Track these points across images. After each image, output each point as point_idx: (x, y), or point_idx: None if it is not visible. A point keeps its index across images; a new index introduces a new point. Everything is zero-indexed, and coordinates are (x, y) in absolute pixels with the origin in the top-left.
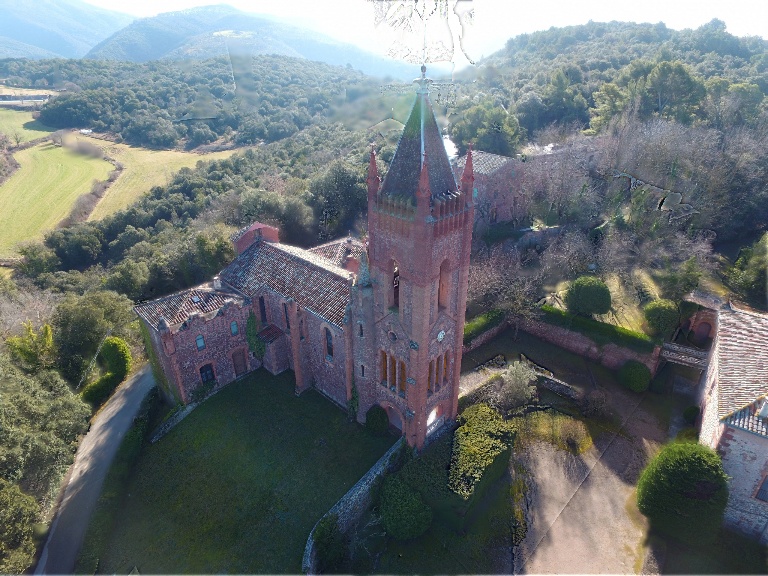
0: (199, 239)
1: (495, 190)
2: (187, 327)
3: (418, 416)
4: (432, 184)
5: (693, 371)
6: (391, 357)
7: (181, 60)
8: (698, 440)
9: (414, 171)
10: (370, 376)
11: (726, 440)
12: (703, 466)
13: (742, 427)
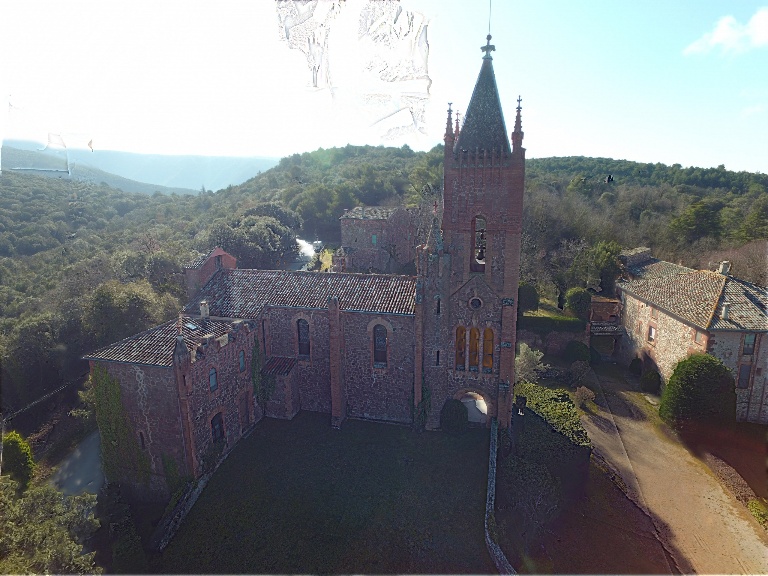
0: (101, 294)
1: (392, 235)
2: (203, 355)
3: (511, 386)
4: None
5: (599, 348)
6: (470, 331)
7: (131, 47)
8: (660, 376)
9: (494, 125)
10: (444, 363)
11: (711, 346)
12: (716, 364)
13: (722, 328)
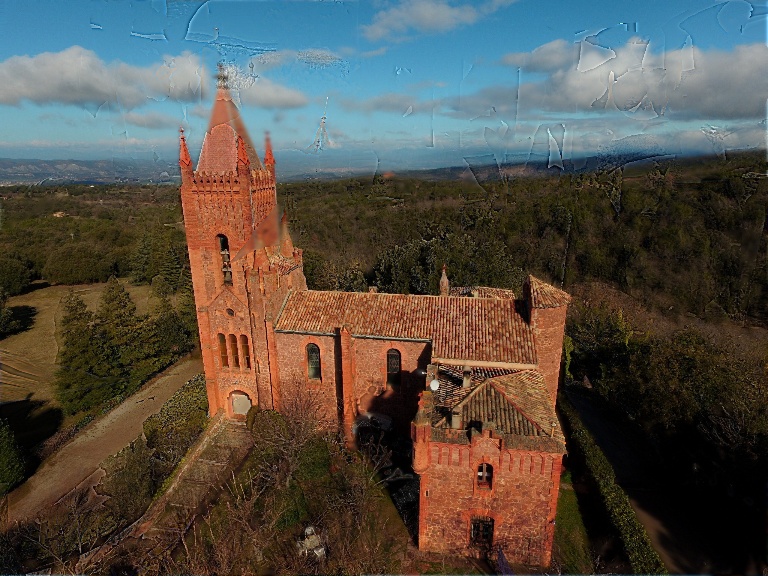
0: None
1: None
2: None
3: None
4: None
5: None
6: None
7: None
8: None
9: None
10: None
11: None
12: None
13: None
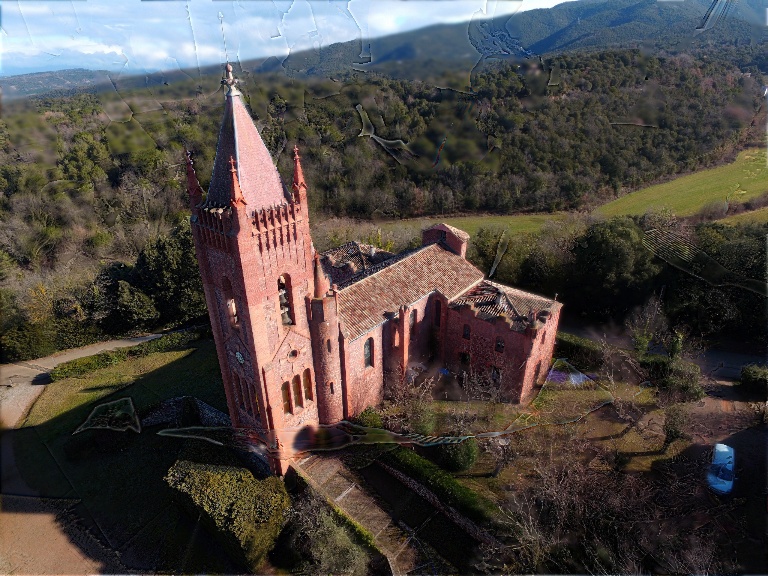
0: None
1: None
2: None
3: None
4: (218, 191)
5: None
6: None
7: None
8: None
9: None
10: None
11: None
12: None
13: None
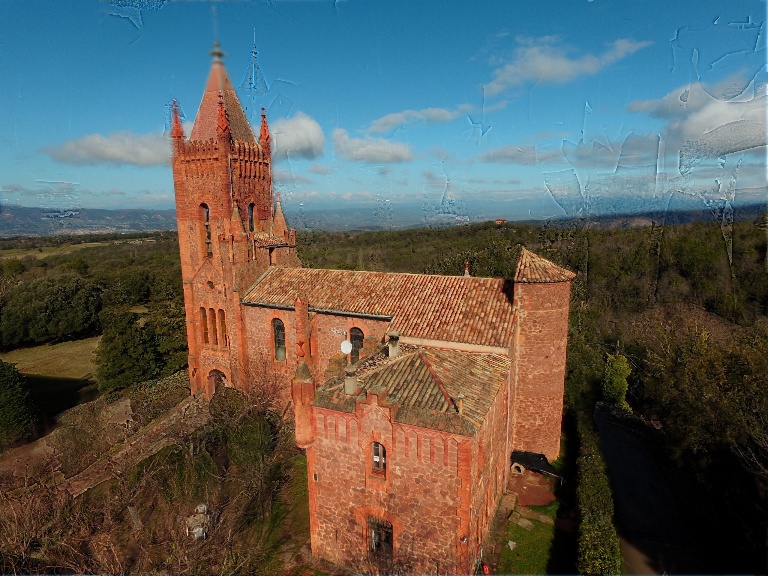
0: None
1: None
2: None
3: None
4: None
5: None
6: None
7: None
8: None
9: None
10: None
11: None
12: None
13: None
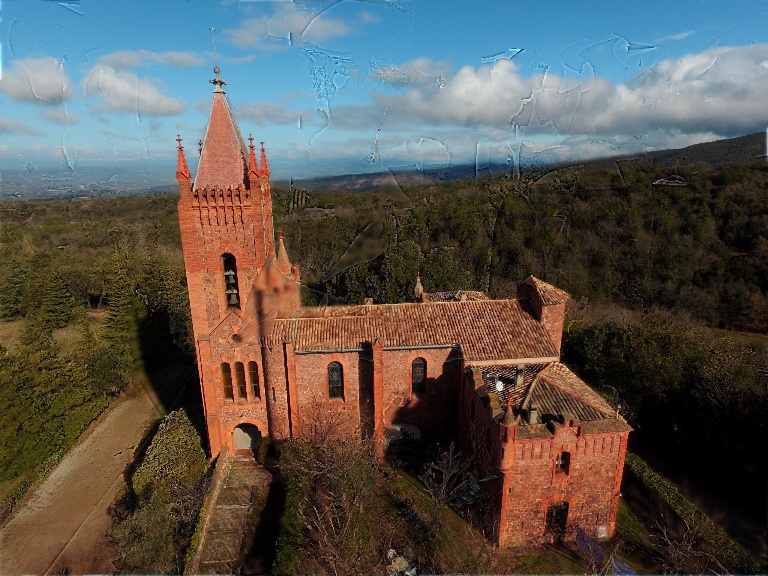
0: None
1: None
2: None
3: None
4: None
5: None
6: None
7: None
8: None
9: None
10: None
11: None
12: None
13: None
